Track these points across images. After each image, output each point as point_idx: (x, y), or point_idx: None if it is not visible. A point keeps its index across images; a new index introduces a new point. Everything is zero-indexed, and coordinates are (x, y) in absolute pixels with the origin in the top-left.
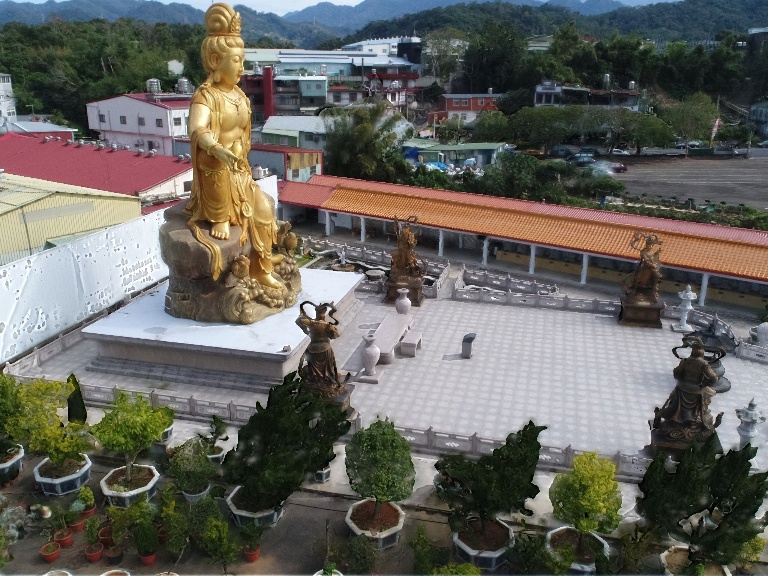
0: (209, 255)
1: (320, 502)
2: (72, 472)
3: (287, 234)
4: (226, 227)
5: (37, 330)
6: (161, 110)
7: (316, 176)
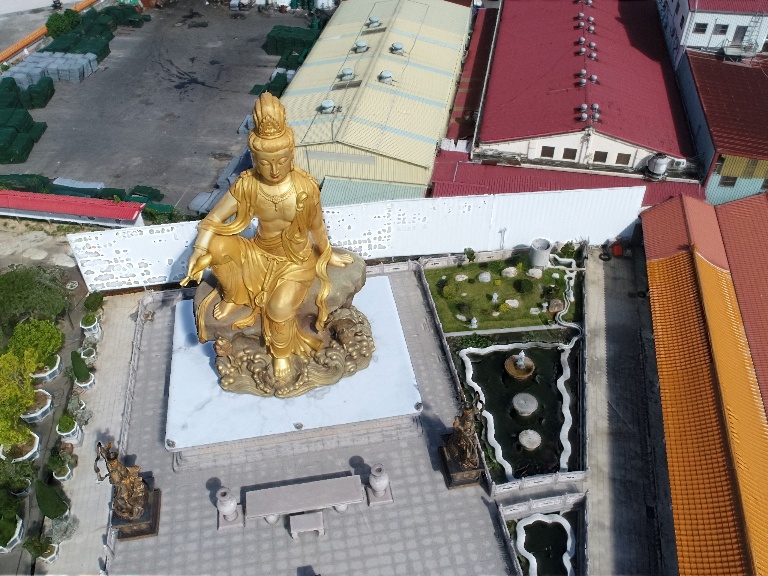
0: (196, 324)
1: (25, 570)
2: (28, 411)
3: (584, 269)
4: (228, 307)
5: (208, 269)
6: (687, 8)
7: (763, 196)
